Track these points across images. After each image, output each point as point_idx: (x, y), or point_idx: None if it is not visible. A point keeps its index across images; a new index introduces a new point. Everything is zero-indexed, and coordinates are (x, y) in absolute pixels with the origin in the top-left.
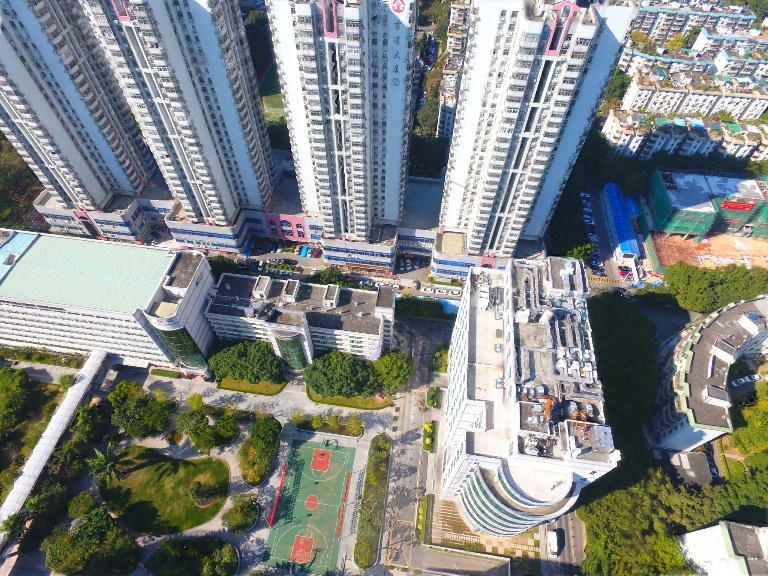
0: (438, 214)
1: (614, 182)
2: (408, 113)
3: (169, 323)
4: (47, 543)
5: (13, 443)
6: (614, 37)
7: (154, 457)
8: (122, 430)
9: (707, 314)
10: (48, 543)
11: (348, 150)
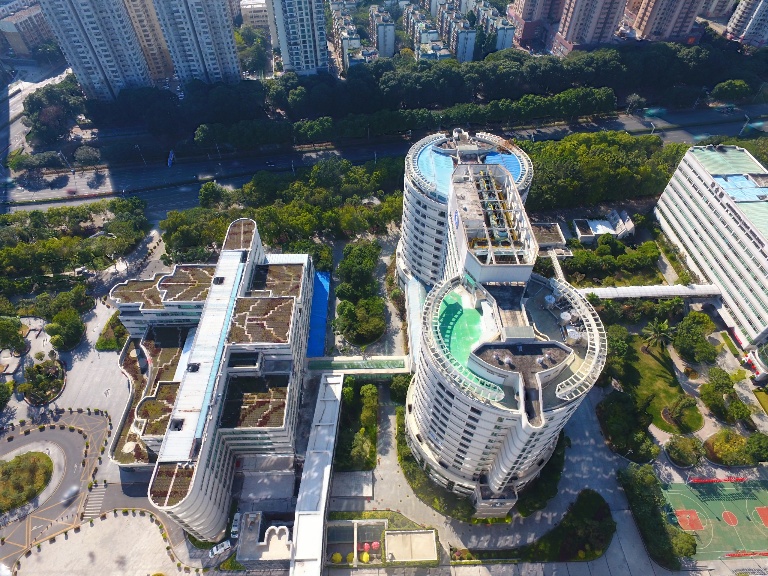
0: None
1: None
2: None
3: None
4: None
5: (618, 274)
6: None
7: (669, 365)
8: None
9: None
10: None
11: None
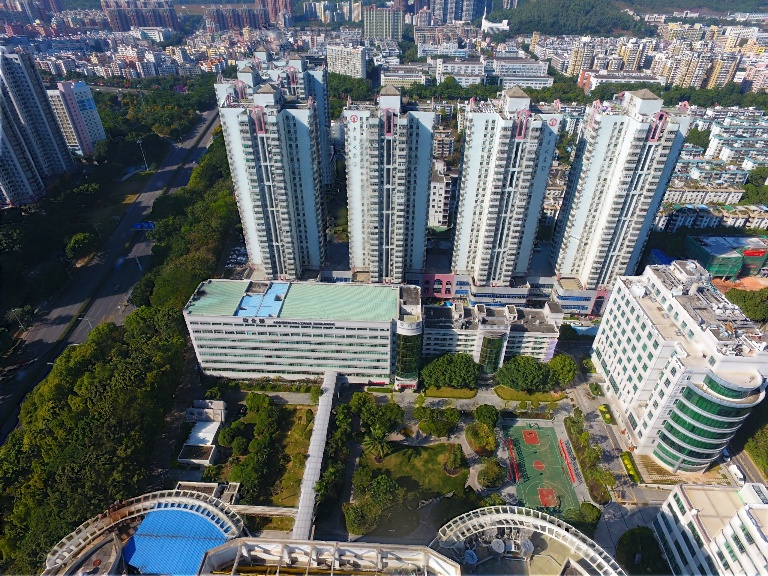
0: (549, 269)
1: (657, 248)
2: None
3: (416, 327)
4: (347, 505)
5: None
6: (681, 133)
7: (397, 446)
8: (362, 430)
9: (767, 320)
10: (348, 505)
11: (512, 212)
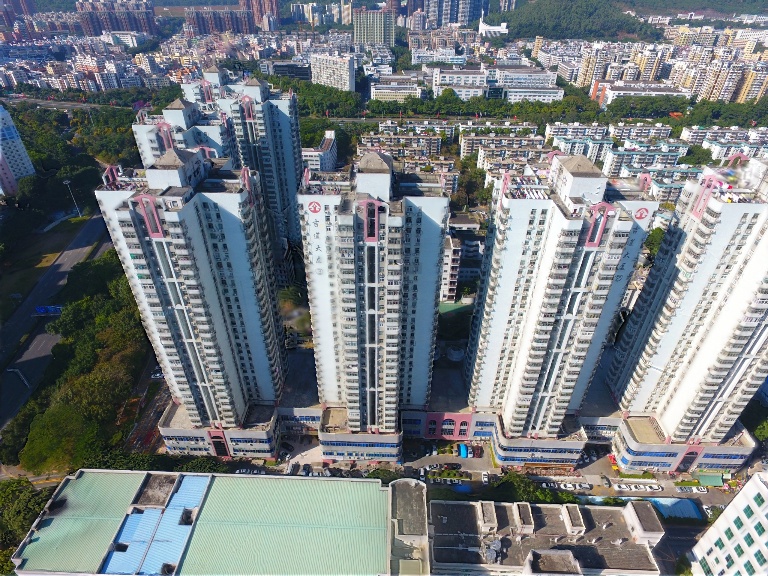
0: (608, 396)
1: None
2: None
3: None
4: None
5: None
6: None
7: None
8: None
9: None
10: None
11: (568, 347)
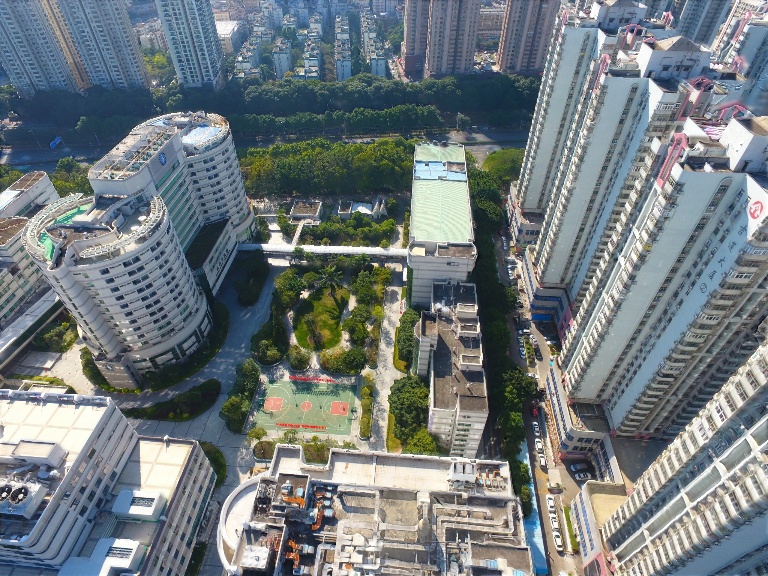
0: None
1: None
2: (694, 332)
3: None
4: None
5: (350, 241)
6: None
7: (342, 305)
8: None
9: None
10: None
11: None
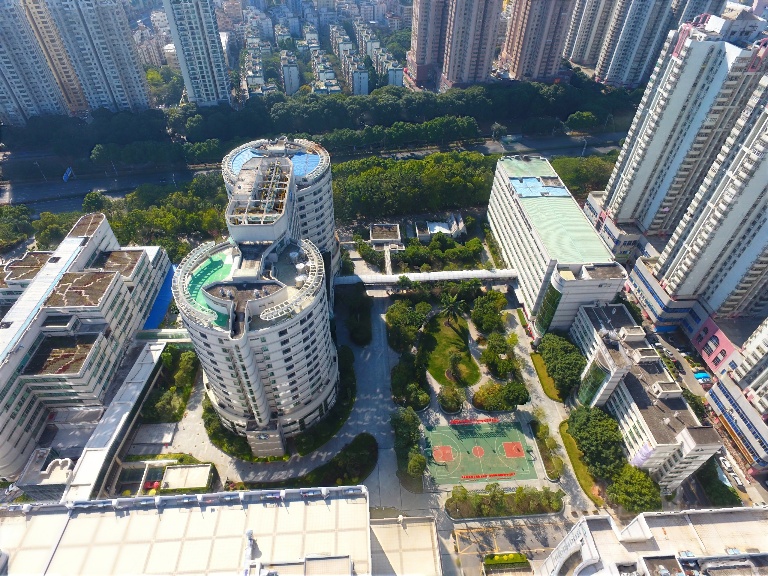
0: None
1: None
2: None
3: (559, 281)
4: (399, 302)
5: (442, 265)
6: None
7: (464, 335)
8: None
9: None
10: (400, 302)
11: None
